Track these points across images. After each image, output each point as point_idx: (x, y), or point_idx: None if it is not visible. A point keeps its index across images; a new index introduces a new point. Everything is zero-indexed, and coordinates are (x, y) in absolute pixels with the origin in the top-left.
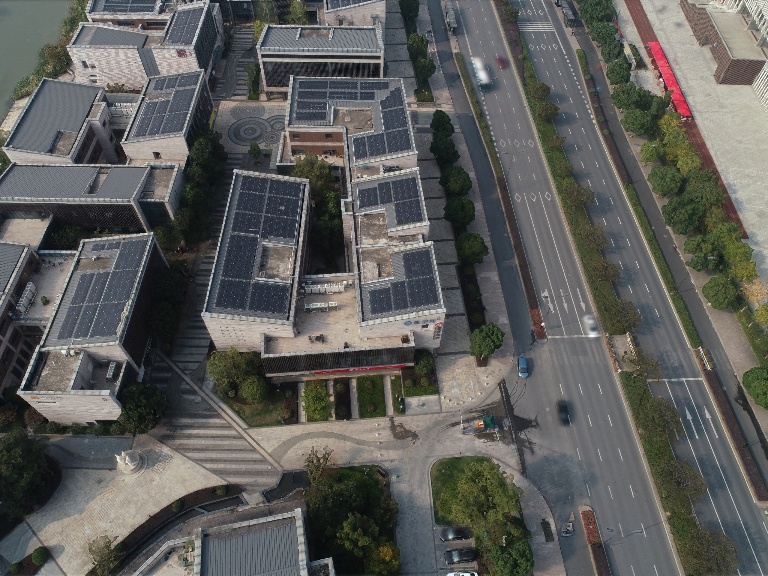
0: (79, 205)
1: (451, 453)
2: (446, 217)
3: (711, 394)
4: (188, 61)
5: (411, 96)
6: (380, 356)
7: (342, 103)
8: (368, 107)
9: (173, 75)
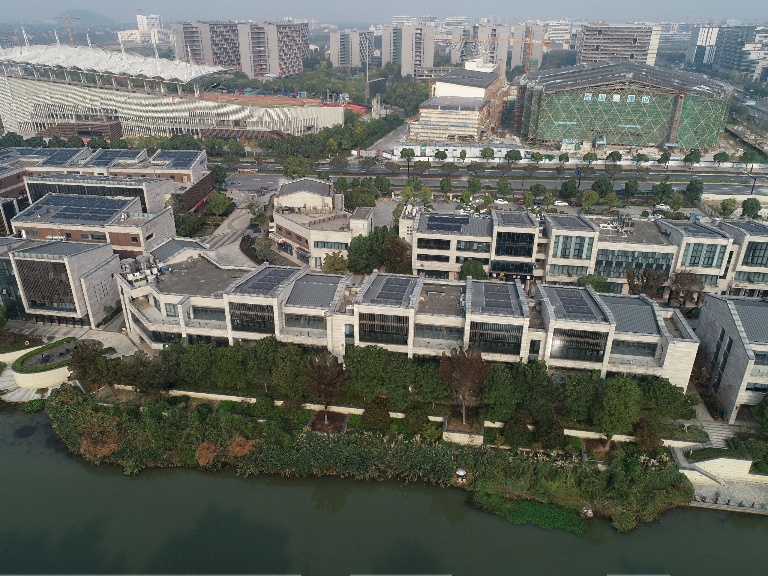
0: None
1: (267, 200)
2: None
3: (279, 164)
4: None
5: None
6: (207, 184)
7: (1, 162)
8: (18, 159)
9: None
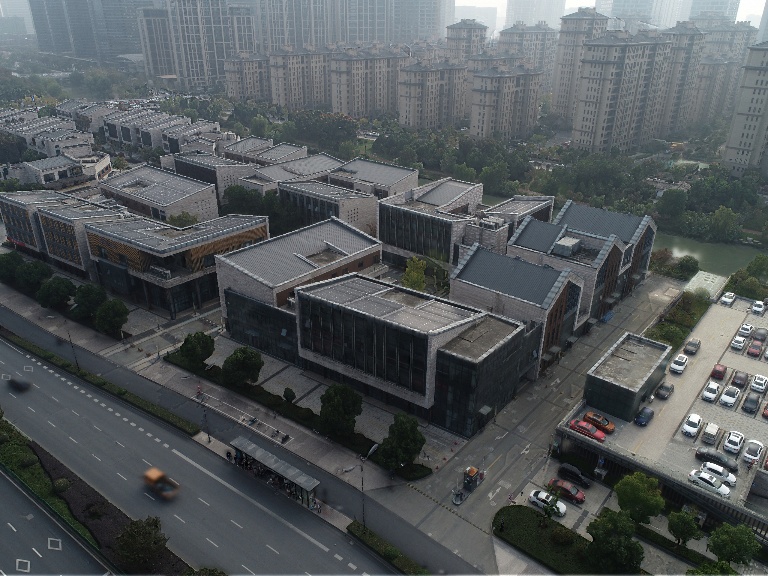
0: None
1: None
2: None
3: None
4: None
5: None
6: None
7: None
8: None
9: None
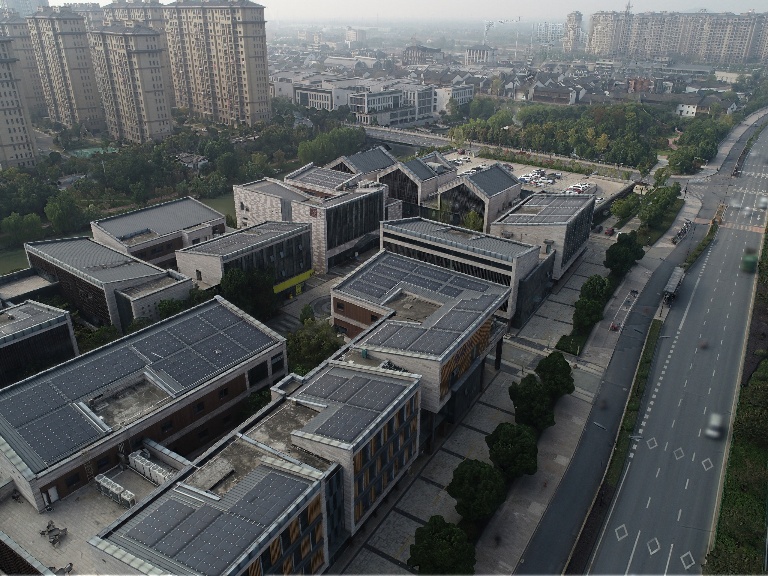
0: (74, 276)
1: None
2: (449, 486)
3: None
4: (317, 222)
5: (553, 340)
6: None
7: (415, 289)
8: (442, 302)
9: (285, 222)
